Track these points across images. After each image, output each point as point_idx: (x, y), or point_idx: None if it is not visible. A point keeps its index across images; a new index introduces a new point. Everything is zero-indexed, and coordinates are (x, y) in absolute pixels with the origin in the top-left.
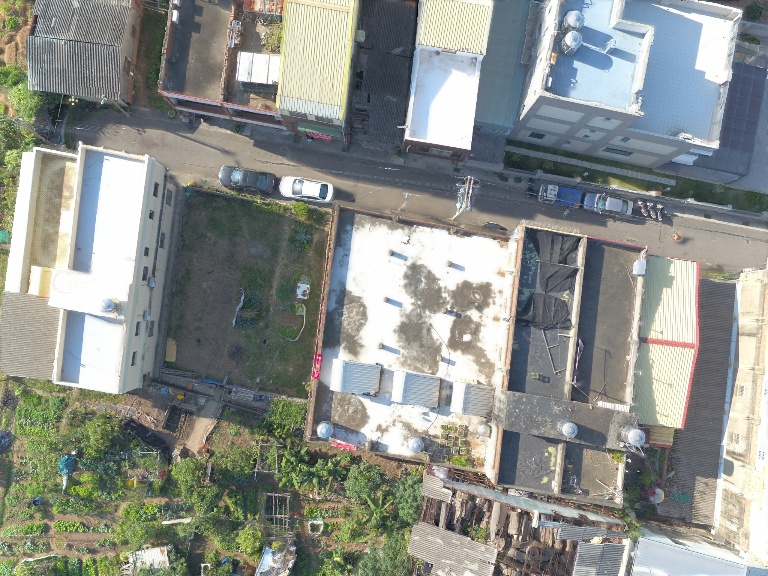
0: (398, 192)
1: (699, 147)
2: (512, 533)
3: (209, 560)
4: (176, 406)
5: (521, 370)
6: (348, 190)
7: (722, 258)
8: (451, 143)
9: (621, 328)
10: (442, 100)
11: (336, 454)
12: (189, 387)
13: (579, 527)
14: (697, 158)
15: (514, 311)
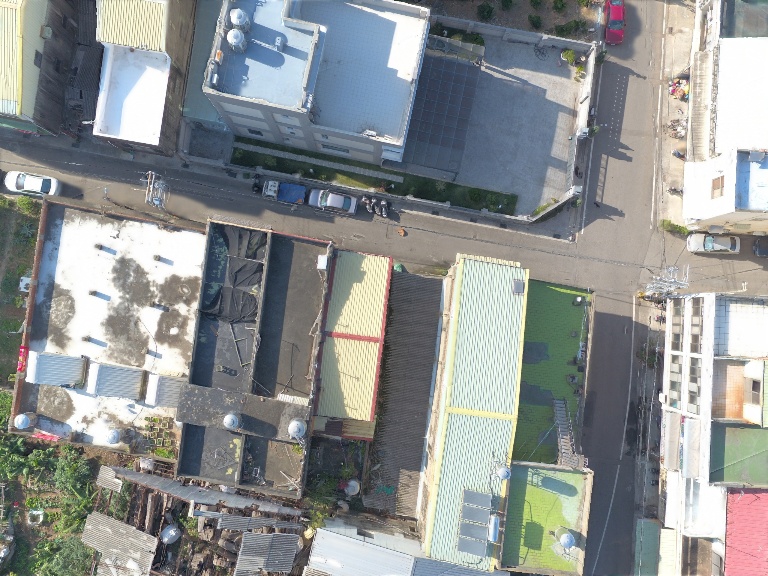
0: (126, 187)
1: (386, 144)
2: None
3: None
4: None
5: (208, 363)
6: (76, 185)
7: (448, 254)
8: (140, 139)
9: (309, 322)
10: (135, 96)
11: (58, 445)
12: None
13: (243, 517)
14: (407, 155)
15: (197, 305)
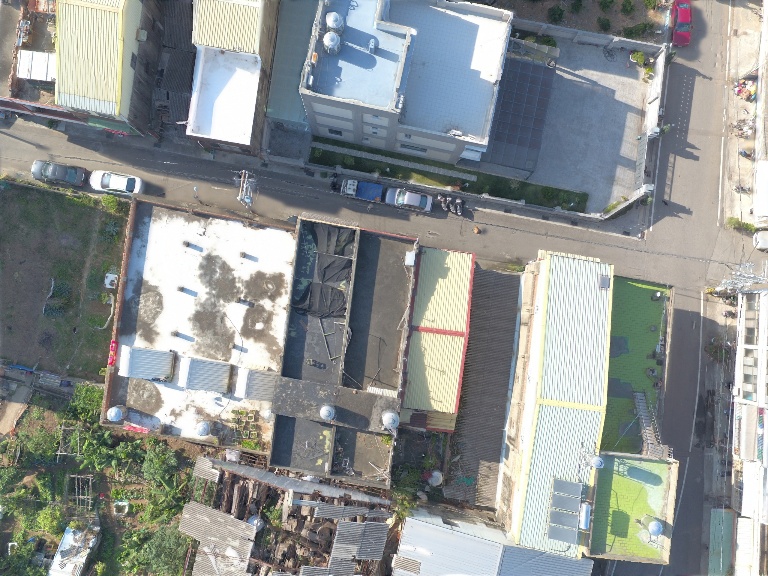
0: (207, 186)
1: (471, 143)
2: (305, 514)
3: (16, 539)
4: None
5: (298, 357)
6: (159, 184)
7: (521, 251)
8: (231, 138)
9: (395, 317)
10: (226, 97)
11: (142, 438)
12: (1, 373)
13: (338, 506)
14: (485, 154)
15: (289, 300)
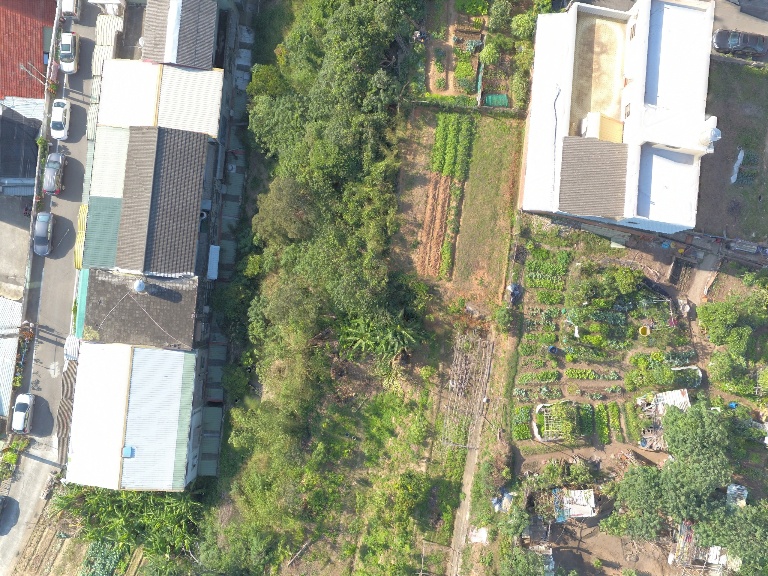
0: None
1: None
2: None
3: (717, 404)
4: (677, 259)
5: None
6: None
7: None
8: None
9: None
10: None
11: None
12: (688, 241)
13: None
14: None
15: None
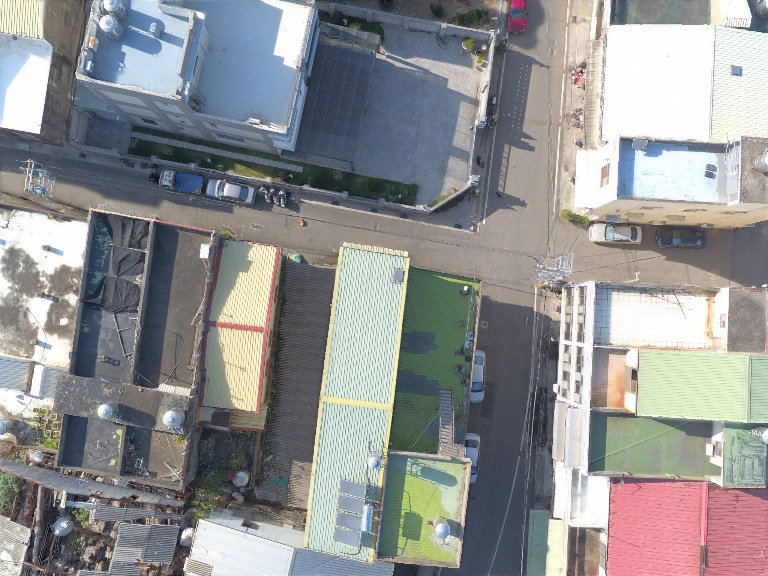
0: (23, 177)
1: (271, 132)
2: None
3: None
4: None
5: (91, 353)
6: None
7: None
8: (21, 127)
9: (193, 312)
10: (18, 84)
11: None
12: None
13: (118, 508)
14: (300, 144)
15: (79, 294)
